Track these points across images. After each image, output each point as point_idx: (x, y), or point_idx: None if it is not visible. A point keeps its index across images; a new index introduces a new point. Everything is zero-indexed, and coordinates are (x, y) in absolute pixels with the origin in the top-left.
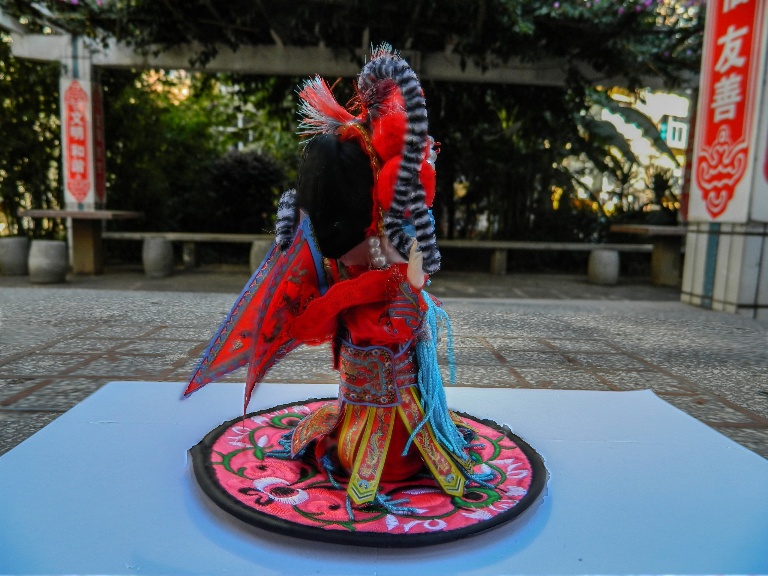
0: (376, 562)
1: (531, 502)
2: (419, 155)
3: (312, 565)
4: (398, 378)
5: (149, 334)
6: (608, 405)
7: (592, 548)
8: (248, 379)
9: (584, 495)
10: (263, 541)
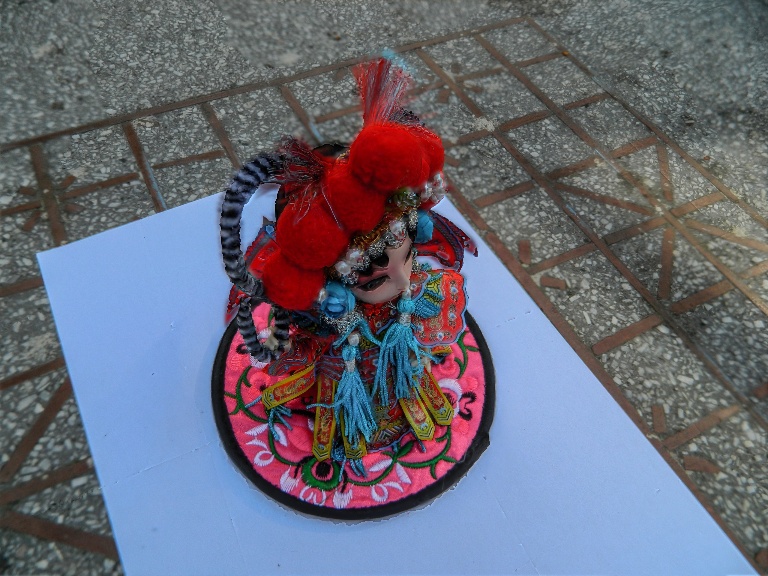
0: (218, 439)
1: (321, 515)
2: (240, 287)
3: (206, 406)
4: (325, 368)
5: (531, 63)
6: (668, 555)
7: (299, 572)
8: (236, 290)
9: (383, 555)
10: (211, 371)
